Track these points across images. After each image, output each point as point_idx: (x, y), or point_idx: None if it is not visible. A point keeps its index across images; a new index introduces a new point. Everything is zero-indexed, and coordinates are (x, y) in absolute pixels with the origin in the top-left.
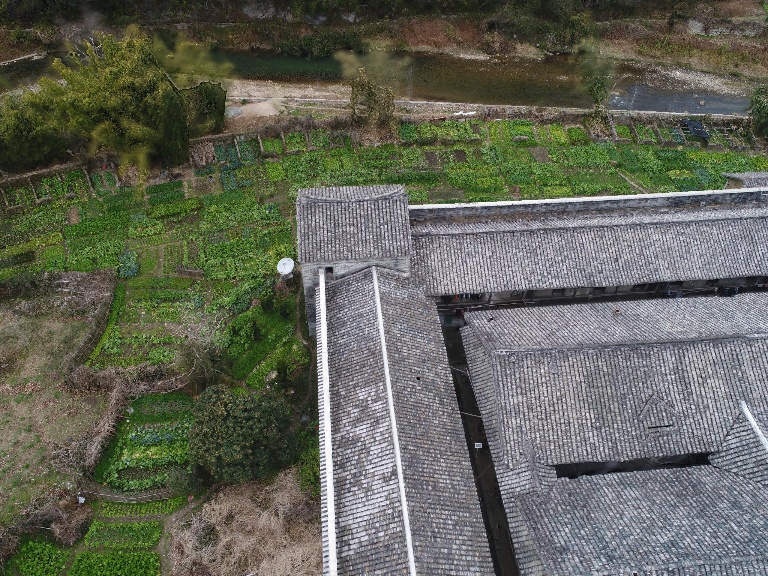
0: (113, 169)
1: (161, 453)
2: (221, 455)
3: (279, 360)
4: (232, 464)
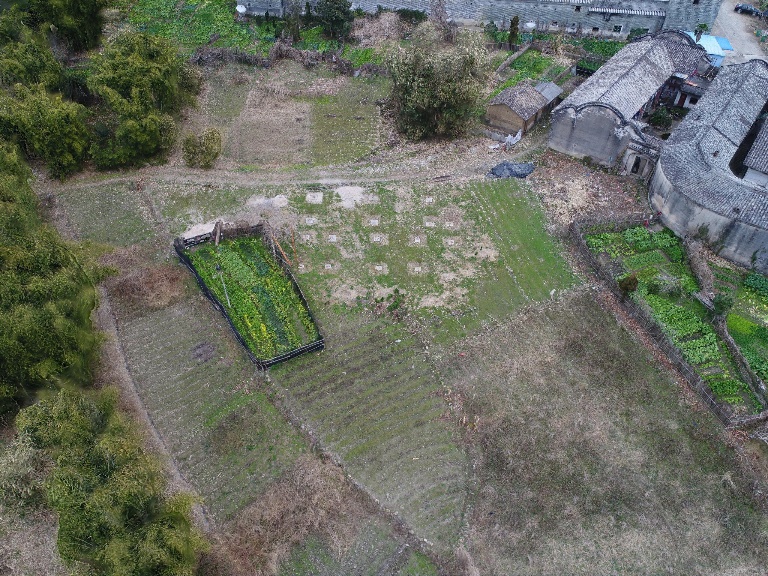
0: (82, 58)
1: (322, 49)
2: (348, 6)
3: (307, 2)
4: (349, 14)
